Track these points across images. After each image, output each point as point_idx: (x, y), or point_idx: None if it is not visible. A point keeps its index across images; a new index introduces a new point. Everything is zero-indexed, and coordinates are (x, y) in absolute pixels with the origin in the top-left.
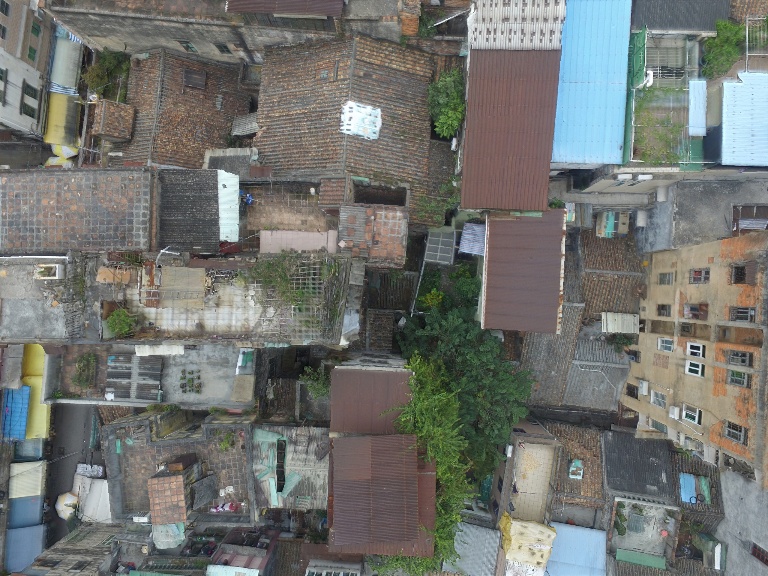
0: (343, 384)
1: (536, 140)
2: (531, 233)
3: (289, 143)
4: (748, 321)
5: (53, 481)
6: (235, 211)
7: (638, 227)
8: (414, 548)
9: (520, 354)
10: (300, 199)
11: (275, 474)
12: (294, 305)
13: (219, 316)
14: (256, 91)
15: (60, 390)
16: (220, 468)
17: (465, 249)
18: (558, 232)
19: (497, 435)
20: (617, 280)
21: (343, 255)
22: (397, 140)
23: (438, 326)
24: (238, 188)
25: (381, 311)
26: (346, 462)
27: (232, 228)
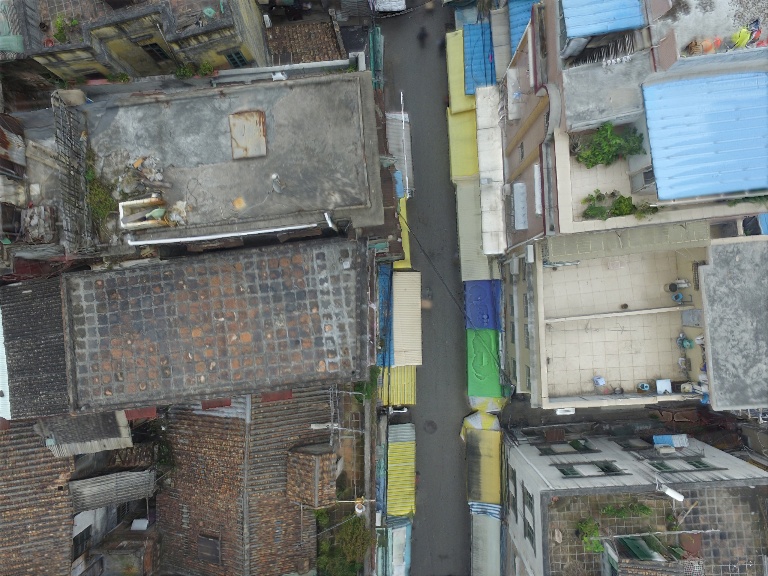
0: None
1: None
2: None
3: None
4: None
5: None
6: None
7: None
8: None
9: None
10: None
11: None
12: None
13: None
14: (136, 538)
15: None
16: None
17: None
18: None
19: None
20: None
21: None
22: None
23: None
24: None
25: None
26: None
27: None
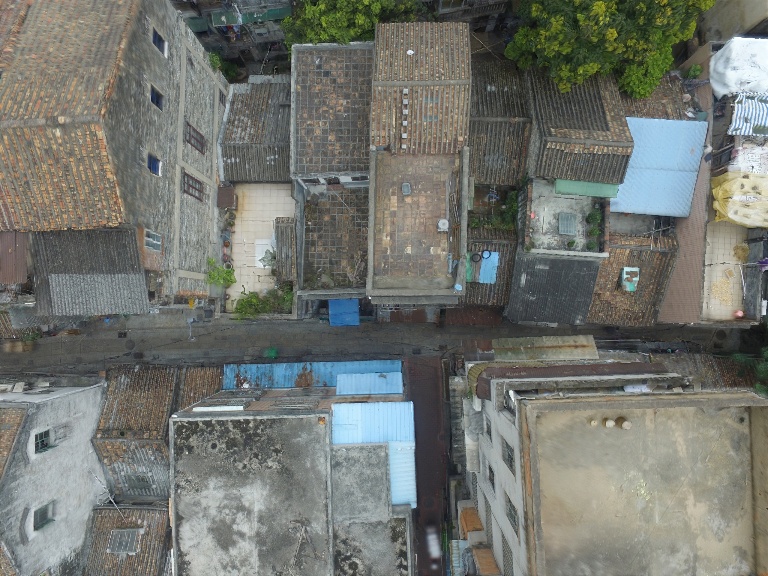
0: None
1: None
2: None
3: None
4: None
5: None
6: None
7: None
8: None
9: None
10: None
11: None
12: None
13: None
14: None
15: None
16: None
17: None
18: None
19: None
20: None
21: None
22: None
23: None
24: None
25: None
26: None
27: None
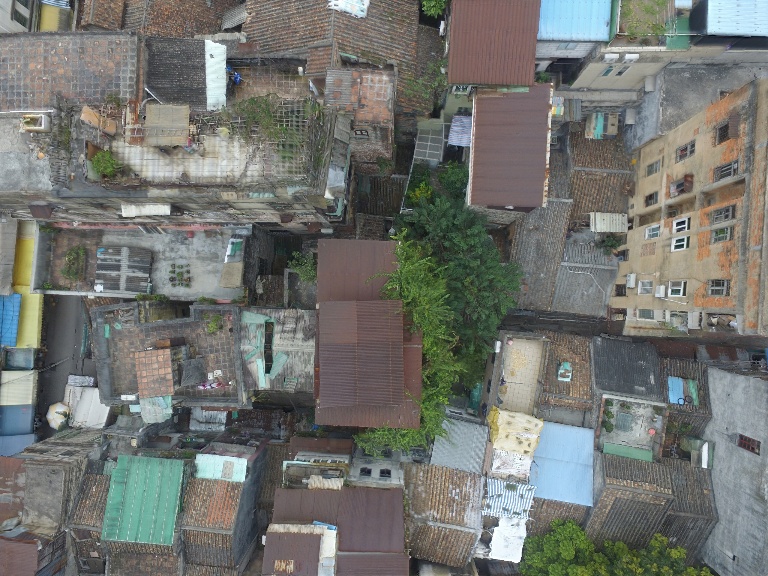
0: (330, 254)
1: (523, 13)
2: (518, 109)
3: (277, 26)
4: (731, 176)
5: (45, 397)
6: (222, 81)
7: (627, 128)
8: (400, 420)
9: (509, 255)
10: (288, 80)
11: (263, 355)
12: (278, 141)
13: (204, 168)
14: None
15: (50, 283)
16: (208, 352)
17: (454, 142)
18: (544, 107)
19: (485, 328)
20: (606, 179)
21: (328, 107)
22: (385, 21)
23: (426, 212)
24: (225, 58)
25: (371, 216)
26: (332, 326)
27: (219, 98)
